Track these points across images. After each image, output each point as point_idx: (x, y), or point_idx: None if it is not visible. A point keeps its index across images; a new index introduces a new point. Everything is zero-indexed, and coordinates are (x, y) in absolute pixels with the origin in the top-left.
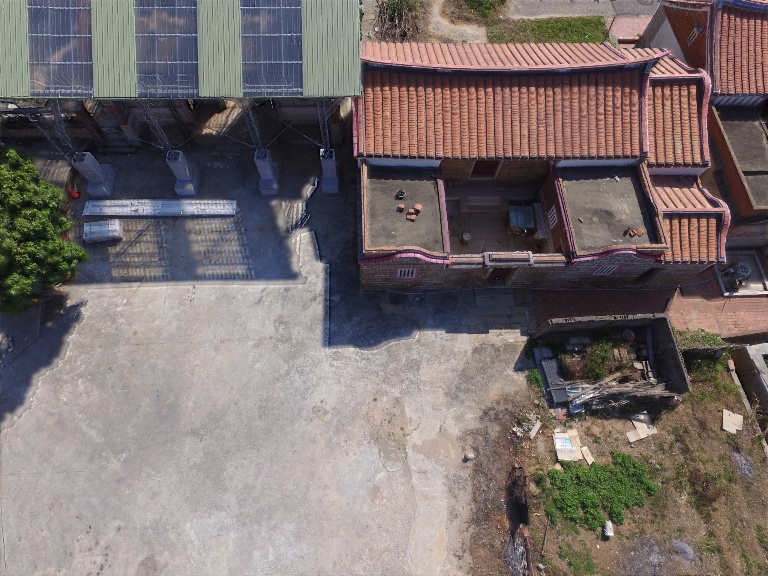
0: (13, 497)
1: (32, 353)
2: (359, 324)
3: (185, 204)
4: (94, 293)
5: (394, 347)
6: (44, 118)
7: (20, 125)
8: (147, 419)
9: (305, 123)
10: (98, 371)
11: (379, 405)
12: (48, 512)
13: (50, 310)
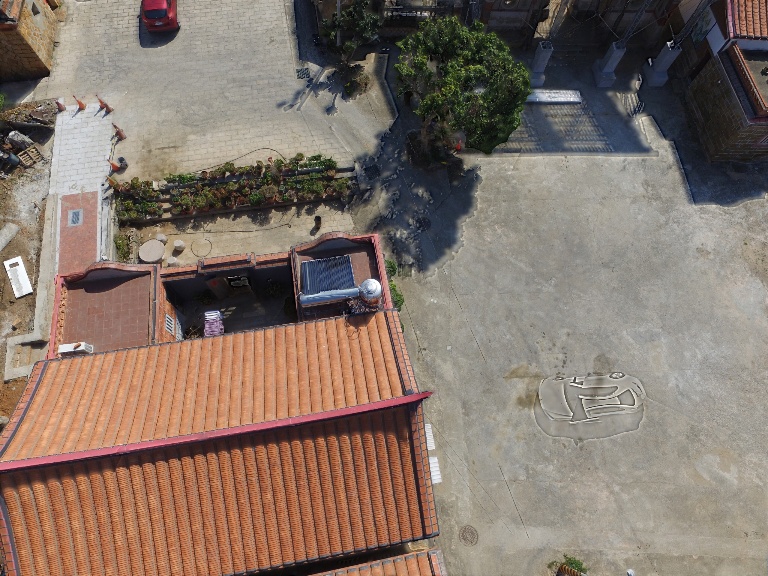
0: (473, 311)
1: (449, 205)
2: (714, 187)
3: (538, 93)
4: (484, 161)
5: (749, 205)
6: (421, 17)
7: (397, 23)
8: (563, 255)
9: (620, 30)
10: (509, 219)
11: (750, 248)
12: (506, 322)
13: (453, 173)
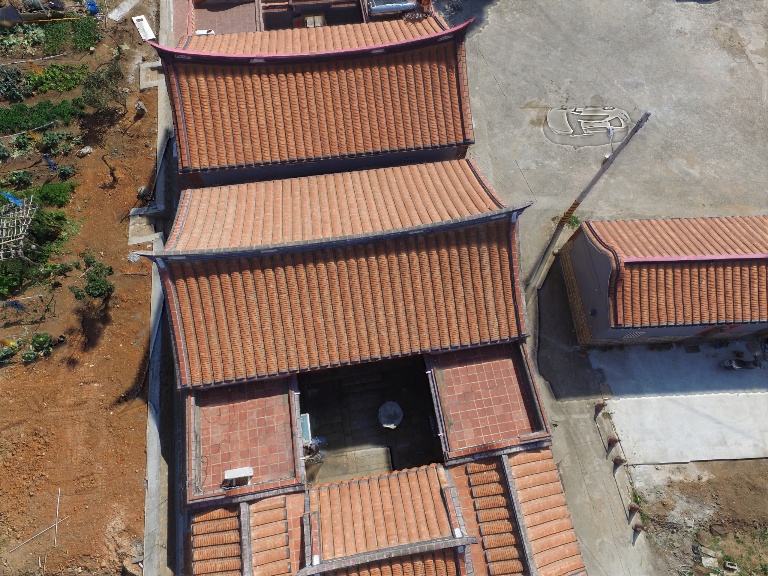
0: (496, 65)
1: None
2: None
3: None
4: None
5: (721, 3)
6: None
7: None
8: (568, 32)
9: None
10: (525, 8)
11: (720, 31)
12: (522, 73)
13: None
